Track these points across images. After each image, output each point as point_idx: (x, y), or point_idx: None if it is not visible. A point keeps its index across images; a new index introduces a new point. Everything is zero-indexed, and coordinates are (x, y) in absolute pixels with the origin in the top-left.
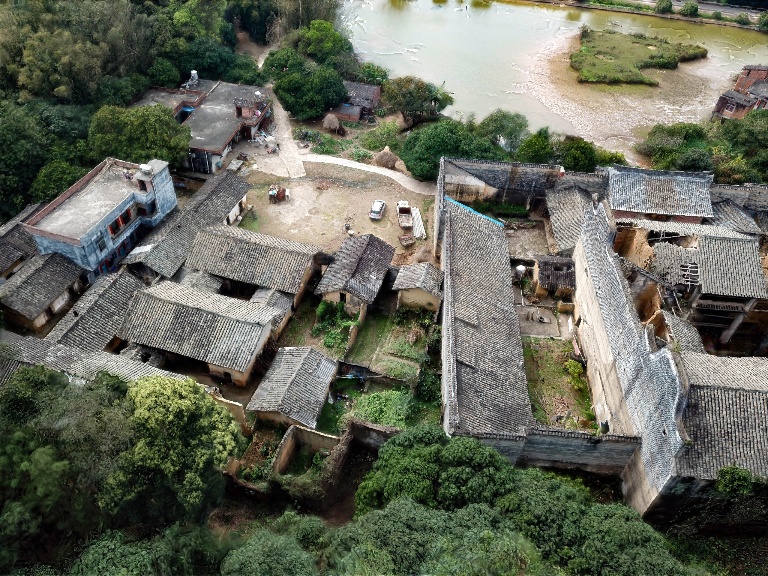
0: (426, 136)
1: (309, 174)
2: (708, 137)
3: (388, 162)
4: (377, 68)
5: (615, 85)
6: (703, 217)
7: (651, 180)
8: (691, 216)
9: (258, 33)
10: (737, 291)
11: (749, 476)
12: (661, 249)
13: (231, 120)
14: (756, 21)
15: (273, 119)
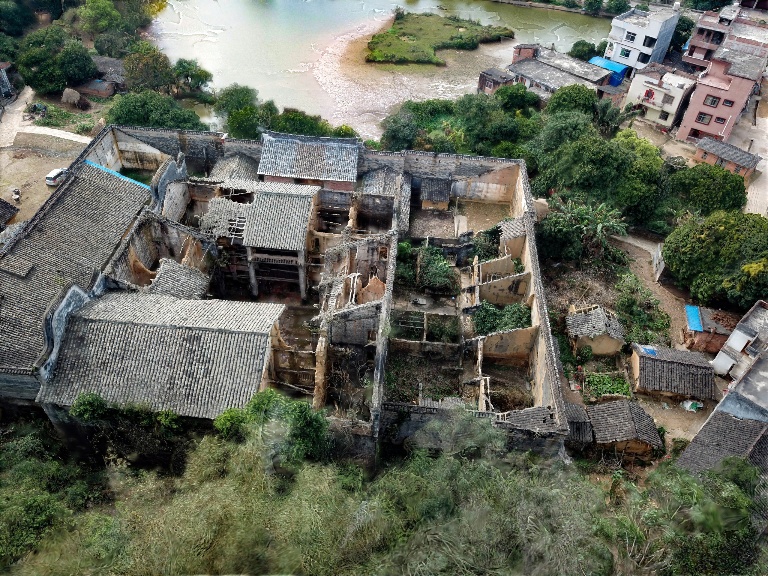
0: (118, 106)
1: (15, 144)
2: (455, 113)
3: None
4: (148, 46)
5: (402, 65)
6: (345, 181)
7: (303, 146)
8: (333, 180)
9: (55, 13)
10: (276, 244)
11: (96, 401)
12: (215, 204)
13: None
14: (583, 5)
15: (17, 94)
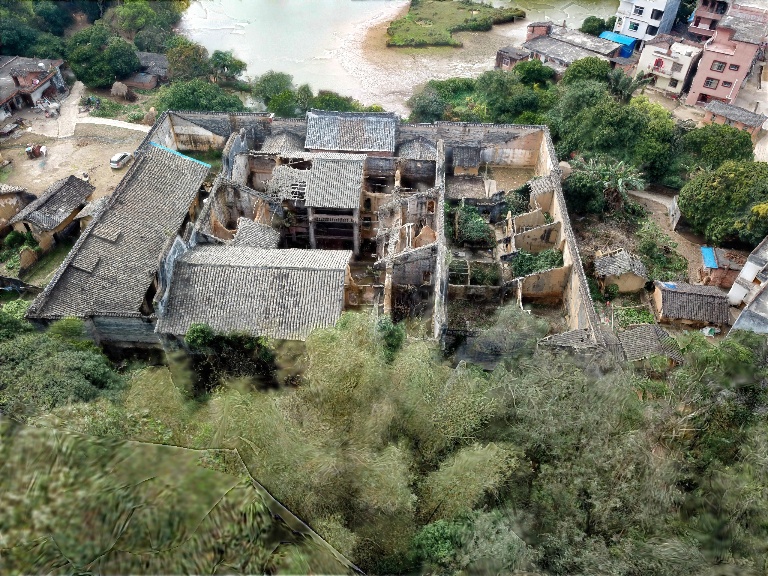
0: (170, 94)
1: (76, 134)
2: None
3: (153, 121)
4: (184, 40)
5: (421, 48)
6: None
7: (345, 122)
8: (374, 151)
9: (92, 14)
10: (335, 203)
11: (207, 329)
12: (278, 171)
13: (10, 89)
14: None
15: (69, 89)
